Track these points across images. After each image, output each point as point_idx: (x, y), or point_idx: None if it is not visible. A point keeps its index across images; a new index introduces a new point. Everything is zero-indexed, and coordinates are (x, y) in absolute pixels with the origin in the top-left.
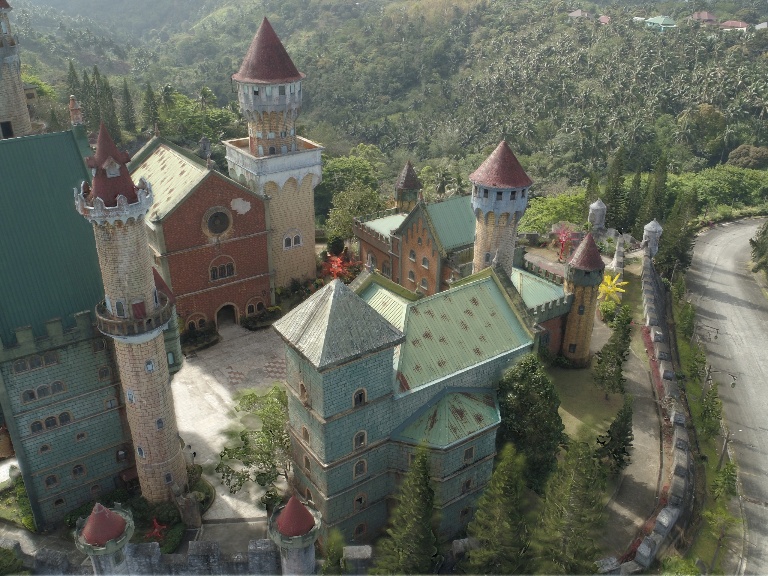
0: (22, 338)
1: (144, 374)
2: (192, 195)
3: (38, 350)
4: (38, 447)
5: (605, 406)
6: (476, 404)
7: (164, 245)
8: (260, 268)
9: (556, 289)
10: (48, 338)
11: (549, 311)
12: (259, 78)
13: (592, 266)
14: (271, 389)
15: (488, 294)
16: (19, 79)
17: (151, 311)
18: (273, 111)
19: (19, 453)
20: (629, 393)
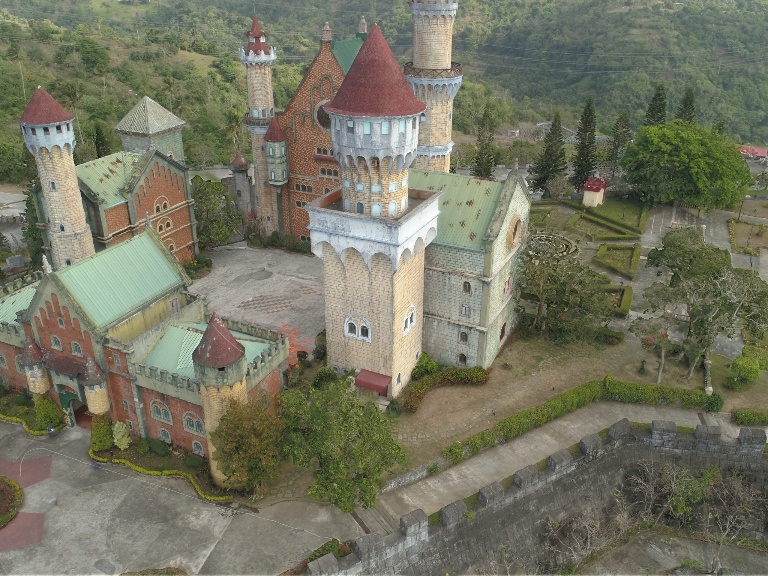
0: None
1: None
2: None
3: None
4: None
5: None
6: None
7: None
8: None
9: None
10: None
11: None
12: None
13: None
14: (271, 290)
15: None
16: None
17: None
18: None
19: None
20: None
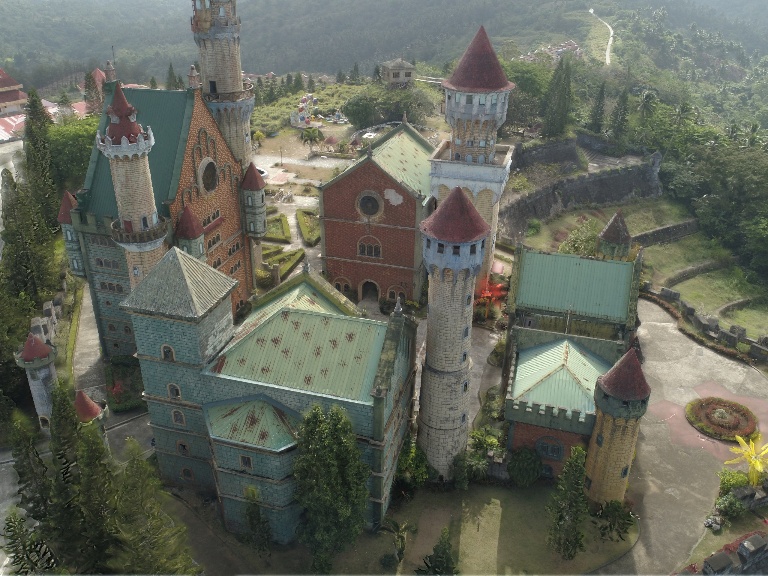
0: (90, 220)
1: (133, 275)
2: (351, 174)
3: (99, 232)
4: (105, 300)
5: (550, 561)
6: (276, 424)
7: (323, 209)
8: (406, 261)
9: (592, 402)
10: (104, 227)
11: (552, 418)
12: (453, 84)
13: (616, 390)
14: None
15: (372, 337)
16: (231, 52)
17: (138, 231)
18: (460, 118)
19: (93, 298)
20: (605, 573)
